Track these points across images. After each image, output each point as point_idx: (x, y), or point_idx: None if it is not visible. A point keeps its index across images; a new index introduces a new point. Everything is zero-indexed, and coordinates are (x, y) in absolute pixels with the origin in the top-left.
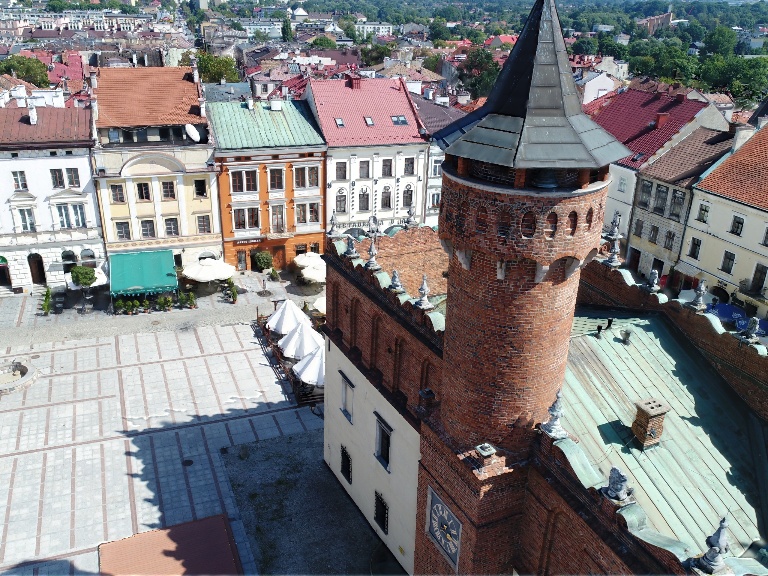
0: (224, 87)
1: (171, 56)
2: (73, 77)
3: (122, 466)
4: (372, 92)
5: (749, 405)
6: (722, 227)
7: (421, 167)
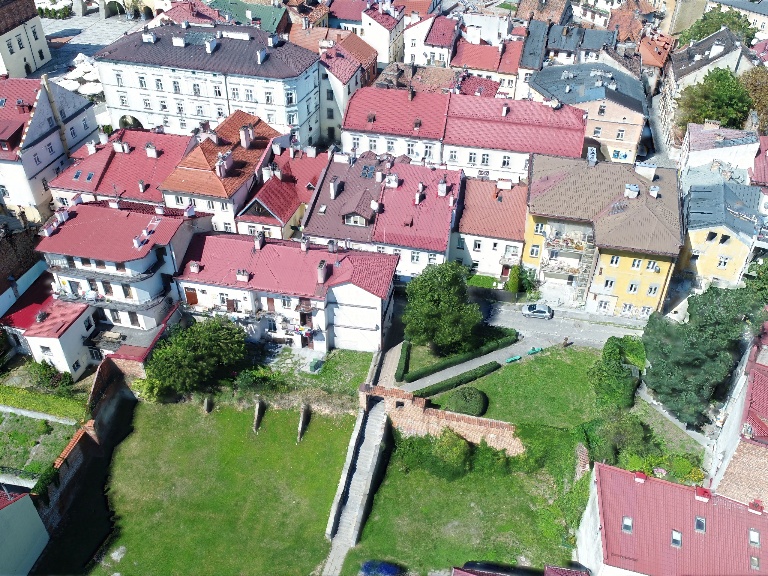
0: (588, 87)
1: None
2: (767, 56)
3: None
4: None
5: None
6: None
7: None
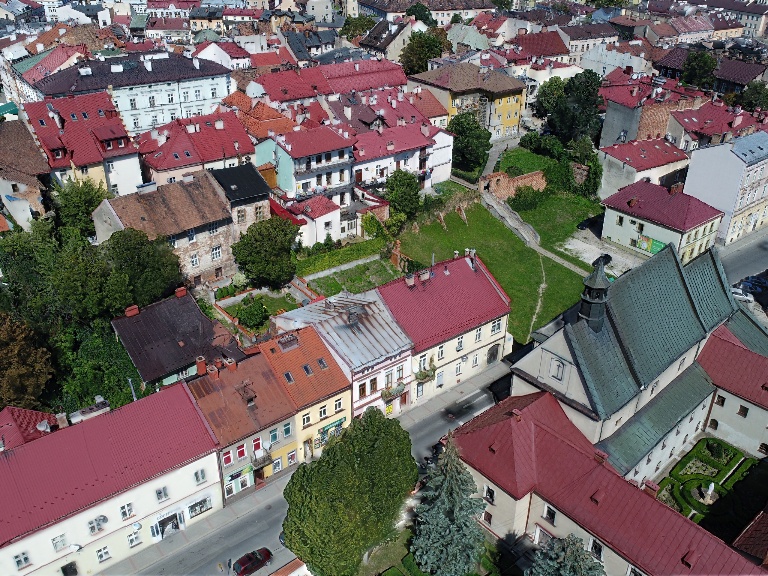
0: None
1: (449, 30)
2: None
3: None
4: None
5: None
6: None
7: None
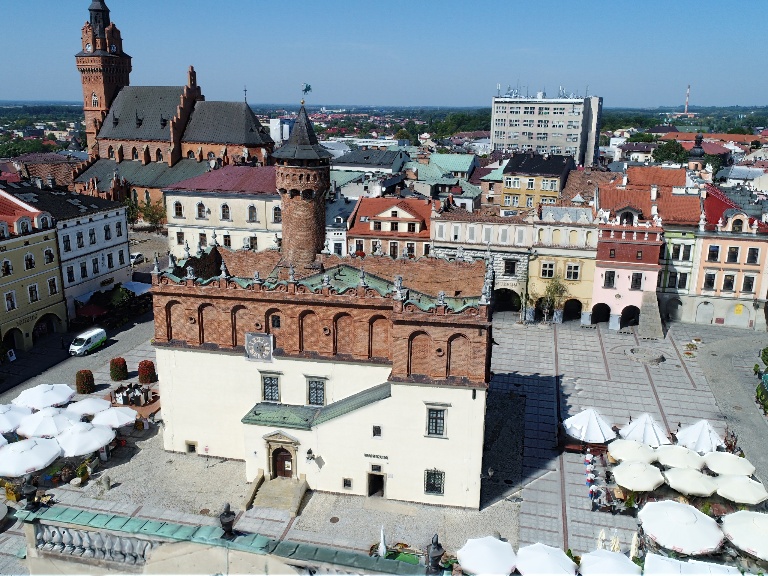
0: None
1: None
2: None
3: (527, 371)
4: None
5: None
6: None
7: None
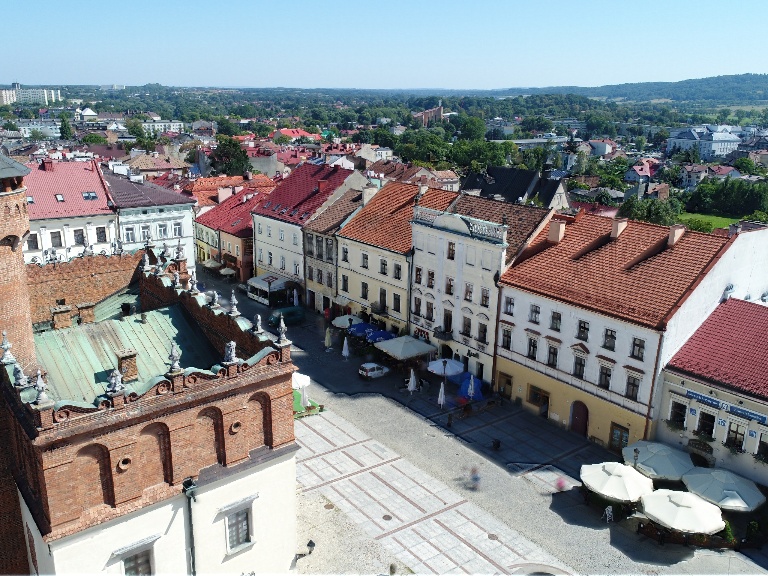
0: None
1: None
2: None
3: None
4: (65, 173)
5: (219, 352)
6: (357, 263)
7: (113, 235)
